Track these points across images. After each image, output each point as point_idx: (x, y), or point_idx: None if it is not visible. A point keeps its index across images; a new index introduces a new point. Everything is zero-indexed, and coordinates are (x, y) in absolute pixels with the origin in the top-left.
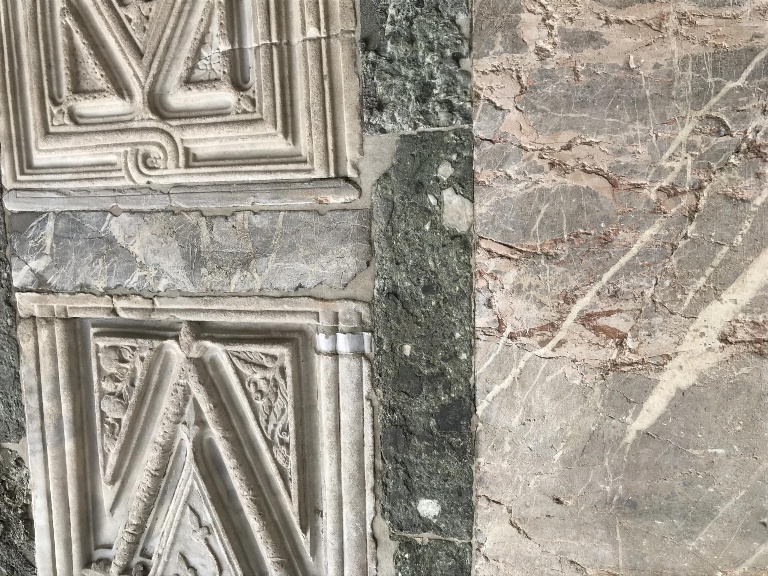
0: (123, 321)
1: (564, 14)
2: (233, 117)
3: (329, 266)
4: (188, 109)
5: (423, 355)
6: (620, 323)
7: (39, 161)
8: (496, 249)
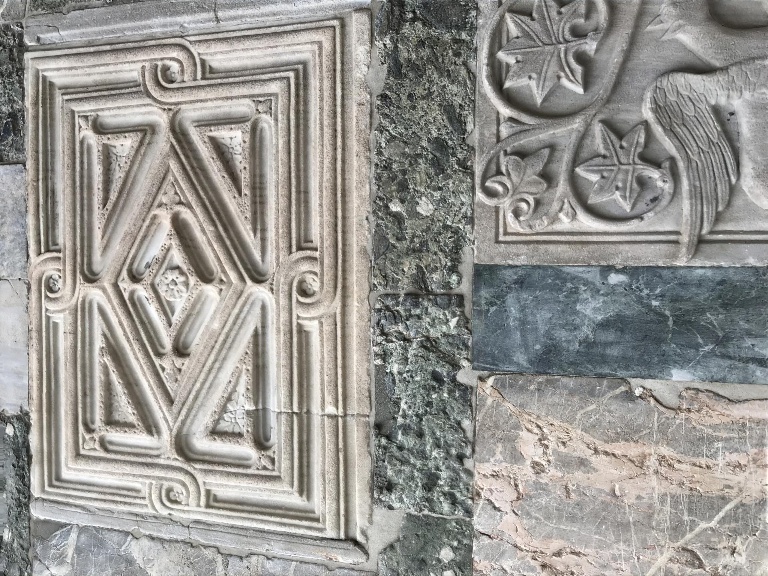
0: None
1: (558, 438)
2: (253, 471)
3: None
4: (212, 453)
5: None
6: None
7: (67, 475)
8: None
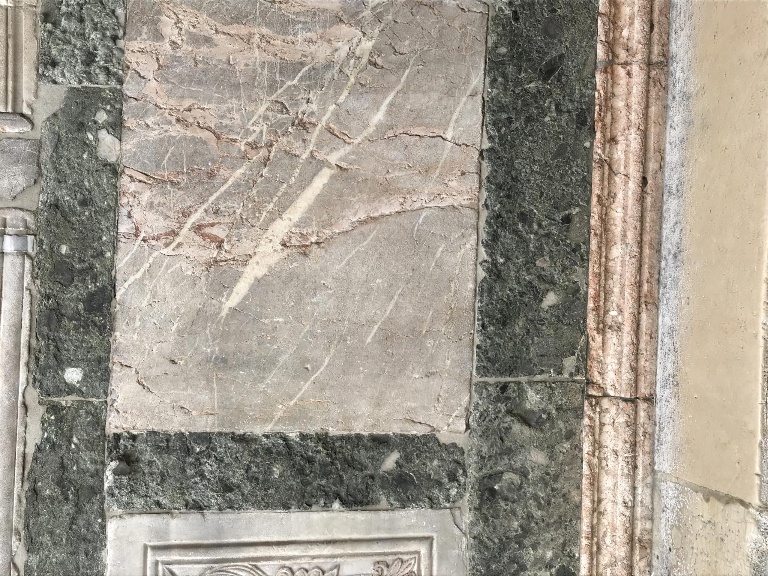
0: None
1: (189, 22)
2: None
3: (1, 181)
4: None
5: (76, 253)
6: (219, 232)
7: None
8: (136, 175)
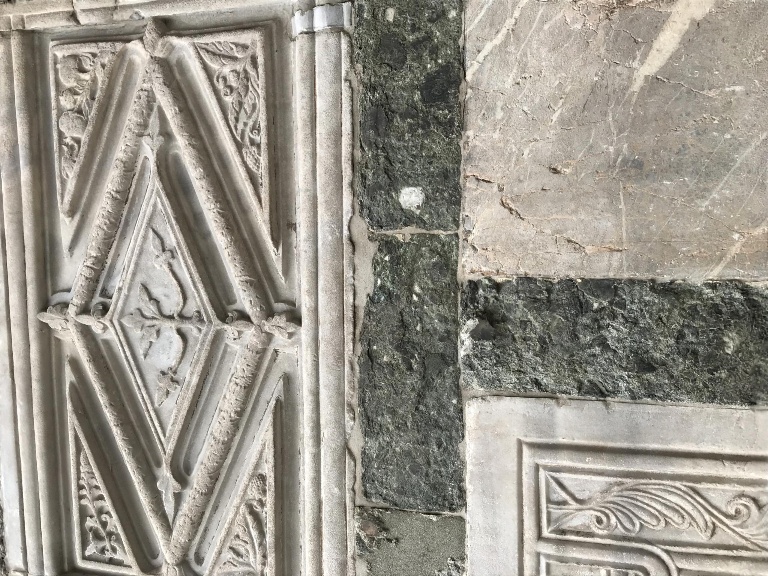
0: (85, 33)
1: None
2: None
3: None
4: None
5: (408, 18)
6: None
7: None
8: None
